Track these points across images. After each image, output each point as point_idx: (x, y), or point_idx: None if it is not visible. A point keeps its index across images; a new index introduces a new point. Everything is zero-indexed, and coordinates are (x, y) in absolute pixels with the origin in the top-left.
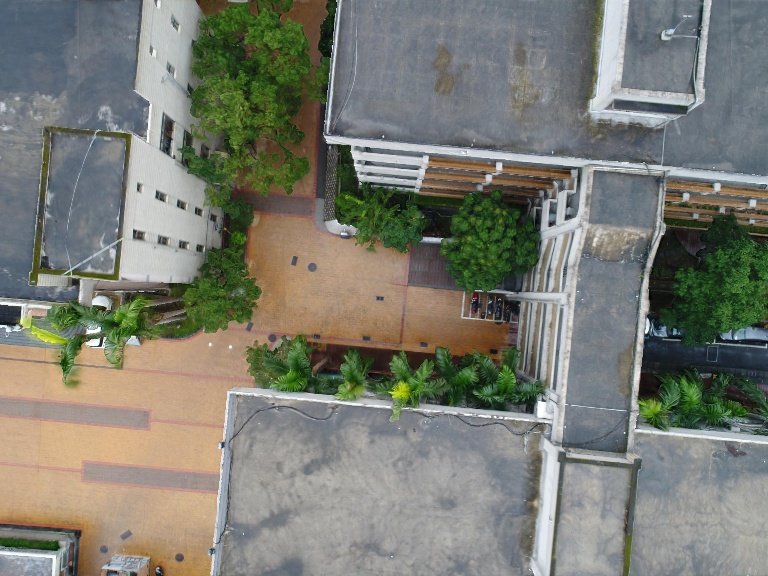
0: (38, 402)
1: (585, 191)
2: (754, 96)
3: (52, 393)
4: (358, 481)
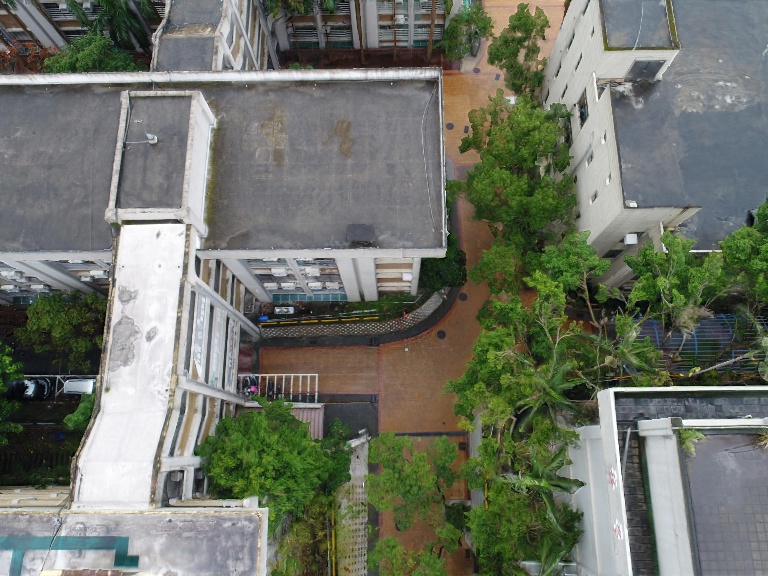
0: None
1: (218, 58)
2: (73, 145)
3: None
4: None
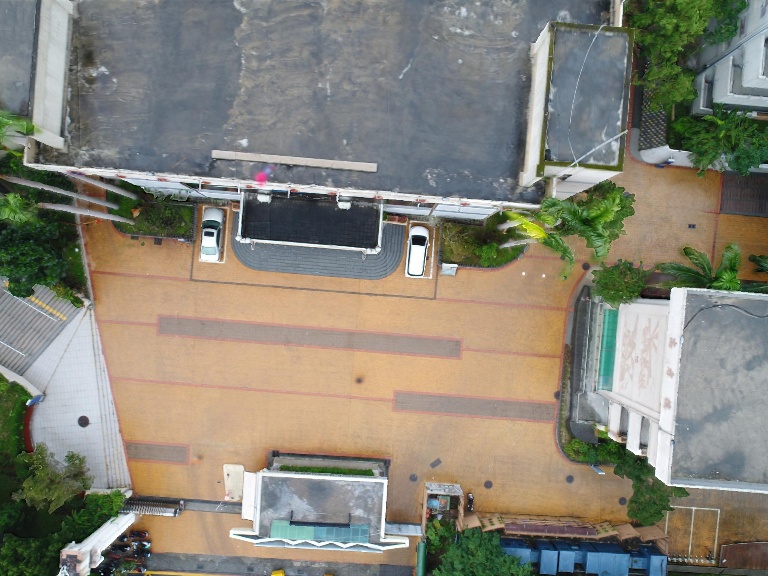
0: (351, 333)
1: None
2: None
3: (365, 324)
4: None
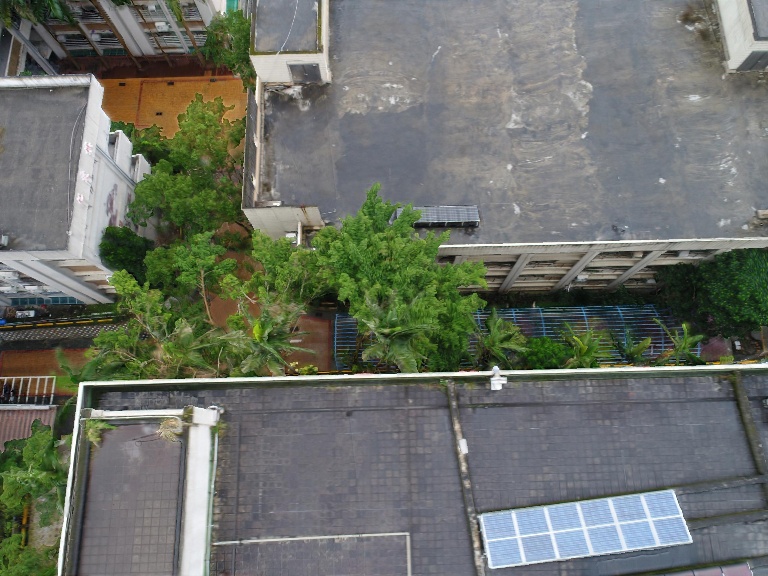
0: None
1: None
2: None
3: None
4: None
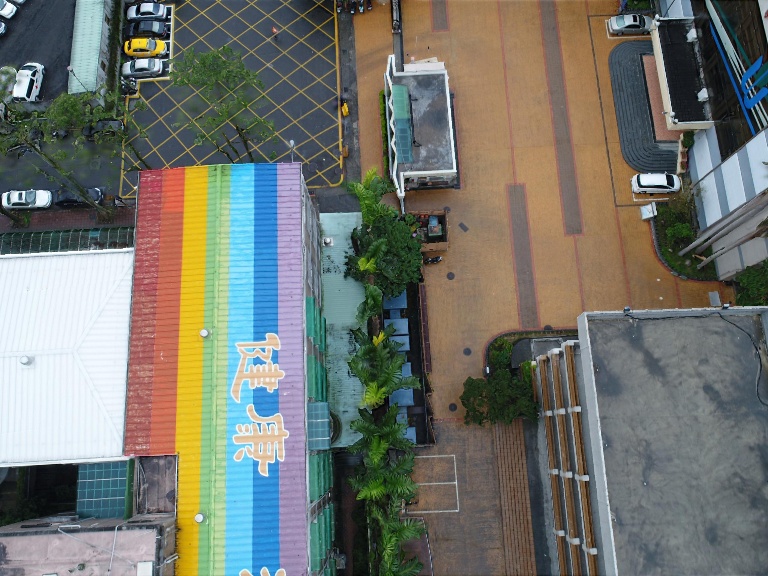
0: (570, 141)
1: None
2: None
3: (581, 152)
4: (710, 439)
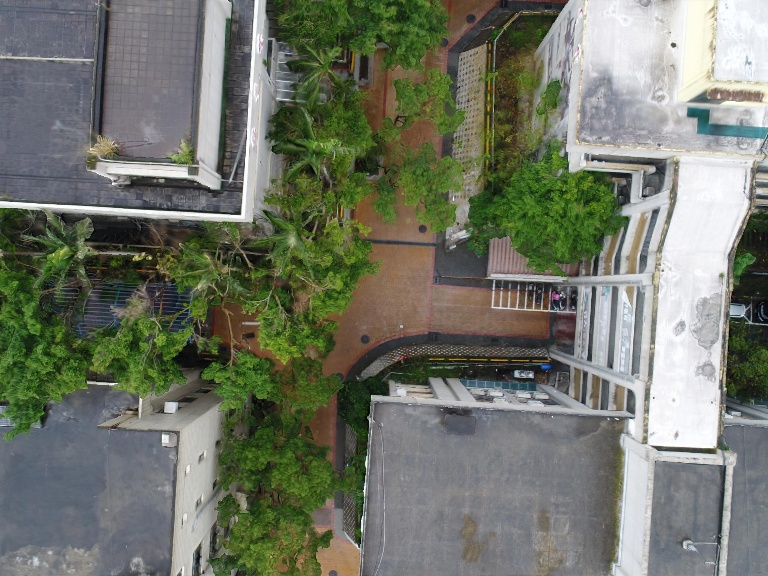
0: None
1: None
2: None
3: None
4: None
